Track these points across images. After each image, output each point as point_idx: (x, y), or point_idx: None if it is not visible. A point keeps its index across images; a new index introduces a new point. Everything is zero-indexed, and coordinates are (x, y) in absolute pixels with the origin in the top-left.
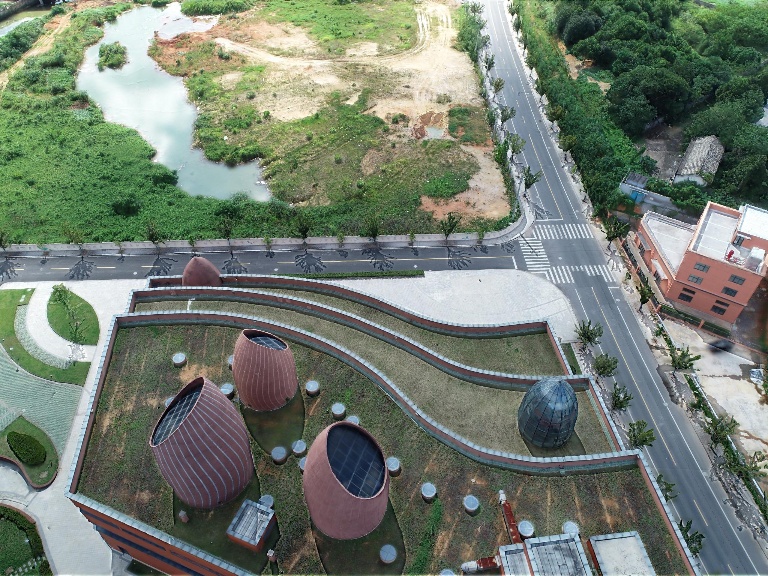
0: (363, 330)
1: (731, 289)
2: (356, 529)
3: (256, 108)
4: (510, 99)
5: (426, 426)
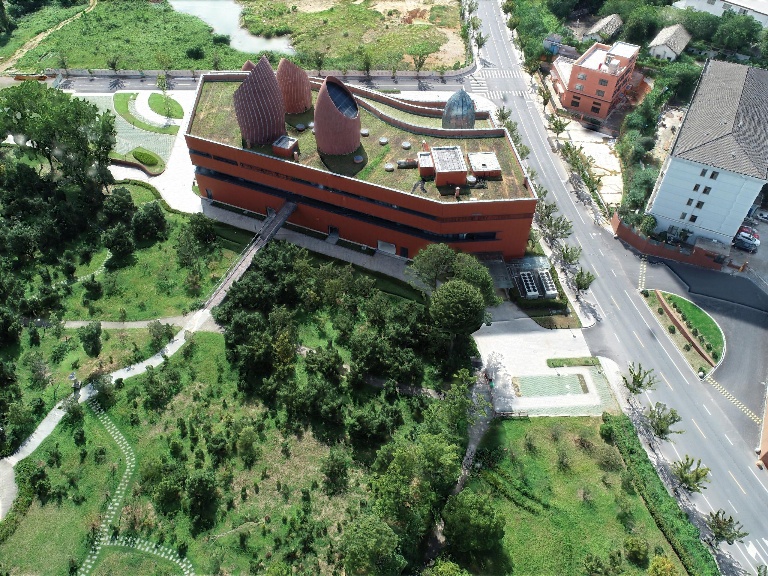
0: None
1: (601, 91)
2: (341, 143)
3: (286, 5)
4: (479, 2)
5: (386, 121)
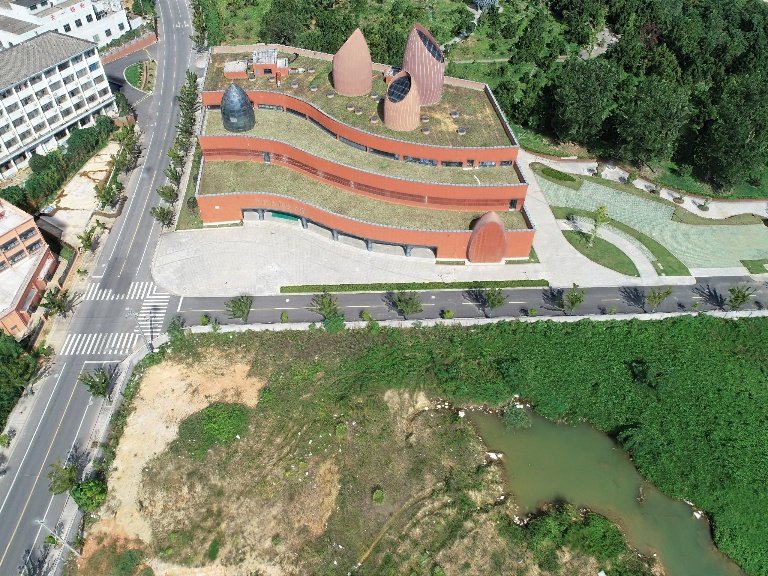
0: None
1: None
2: None
3: None
4: None
5: None
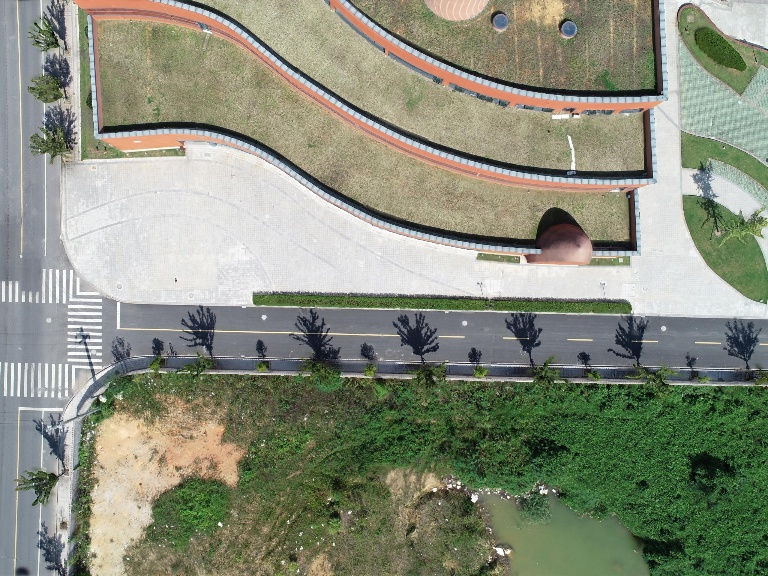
0: (341, 100)
1: None
2: None
3: None
4: None
5: None
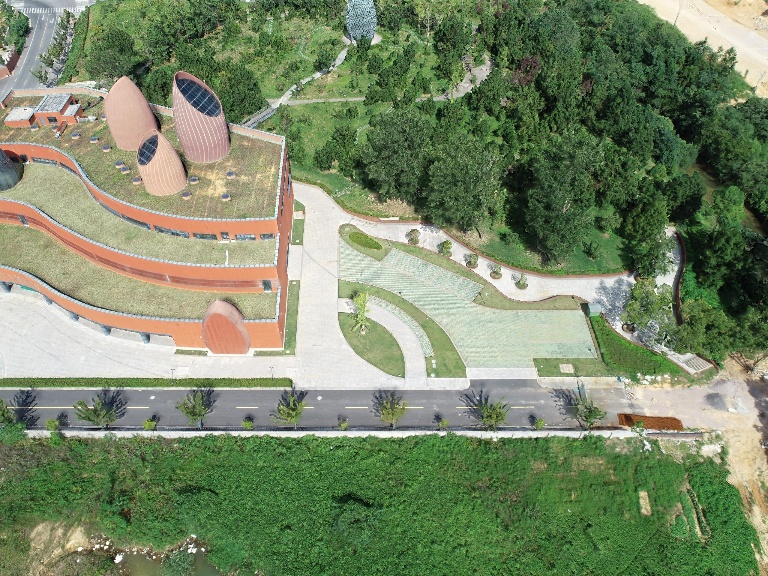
0: None
1: None
2: None
3: None
4: None
5: None
